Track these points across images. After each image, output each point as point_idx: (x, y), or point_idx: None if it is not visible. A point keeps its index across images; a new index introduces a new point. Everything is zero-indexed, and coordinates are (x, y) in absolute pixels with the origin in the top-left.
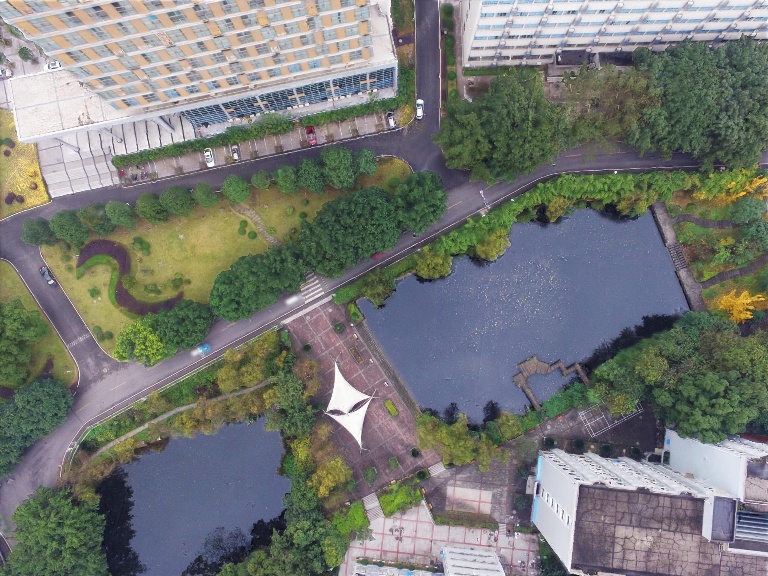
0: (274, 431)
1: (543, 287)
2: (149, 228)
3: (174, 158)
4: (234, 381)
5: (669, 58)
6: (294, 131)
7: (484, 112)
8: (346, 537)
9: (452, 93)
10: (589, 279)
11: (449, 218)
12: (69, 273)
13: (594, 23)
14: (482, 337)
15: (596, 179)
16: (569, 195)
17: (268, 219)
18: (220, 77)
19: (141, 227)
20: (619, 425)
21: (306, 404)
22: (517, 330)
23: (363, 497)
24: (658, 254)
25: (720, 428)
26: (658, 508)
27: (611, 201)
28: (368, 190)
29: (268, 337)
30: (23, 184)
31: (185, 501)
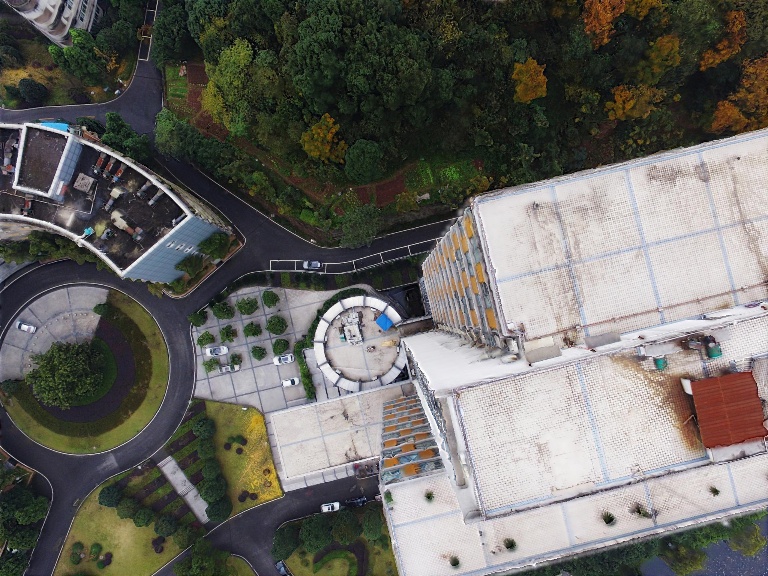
0: None
1: None
2: None
3: None
4: None
5: None
6: None
7: None
8: None
9: None
10: None
11: None
12: (305, 567)
13: None
14: None
15: None
16: None
17: None
18: None
19: None
20: None
21: None
22: None
23: None
24: None
25: None
26: None
27: None
28: None
29: None
30: (256, 481)
31: None
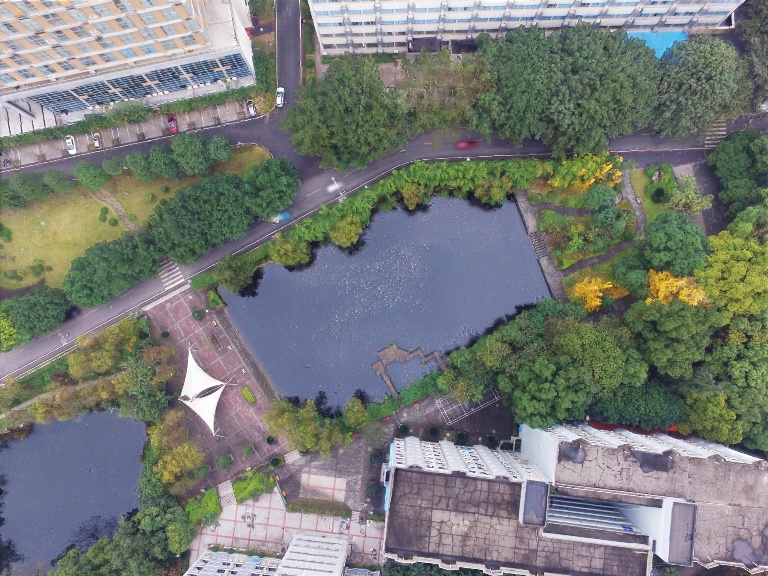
0: (127, 417)
1: (404, 275)
2: (11, 215)
3: (37, 145)
4: (83, 366)
5: (503, 43)
6: (156, 119)
7: (319, 97)
8: (191, 523)
9: (309, 81)
10: (450, 267)
11: (308, 205)
12: None
13: (432, 9)
14: (342, 324)
15: (450, 166)
16: (426, 182)
17: (129, 206)
18: (50, 61)
19: (3, 214)
20: (475, 413)
21: (158, 390)
22: (377, 318)
23: (218, 484)
24: (520, 242)
25: (551, 413)
26: (475, 492)
27: (469, 188)
28: (218, 176)
29: (122, 323)
30: None
31: (47, 488)
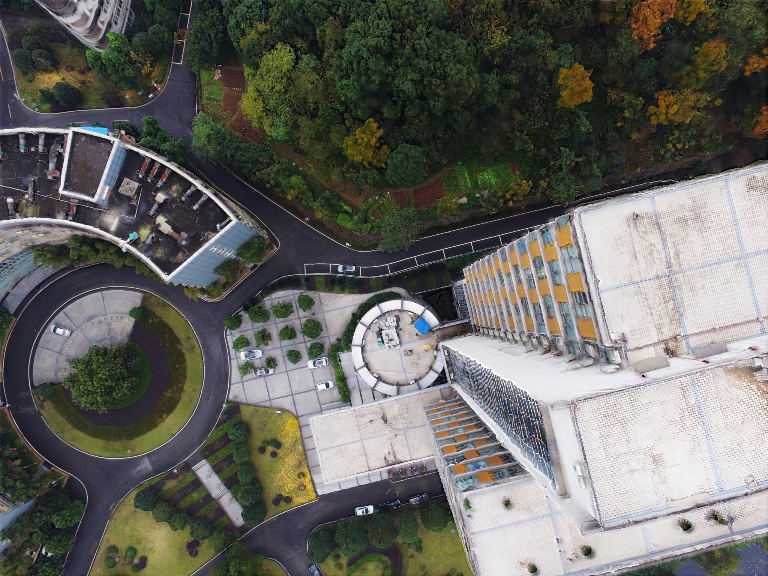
0: None
1: None
2: (420, 523)
3: None
4: None
5: None
6: None
7: None
8: None
9: None
10: None
11: None
12: (339, 570)
13: None
14: None
15: None
16: None
17: None
18: None
19: None
20: None
21: None
22: None
23: None
24: None
25: None
26: None
27: None
28: None
29: None
30: (291, 485)
31: None
